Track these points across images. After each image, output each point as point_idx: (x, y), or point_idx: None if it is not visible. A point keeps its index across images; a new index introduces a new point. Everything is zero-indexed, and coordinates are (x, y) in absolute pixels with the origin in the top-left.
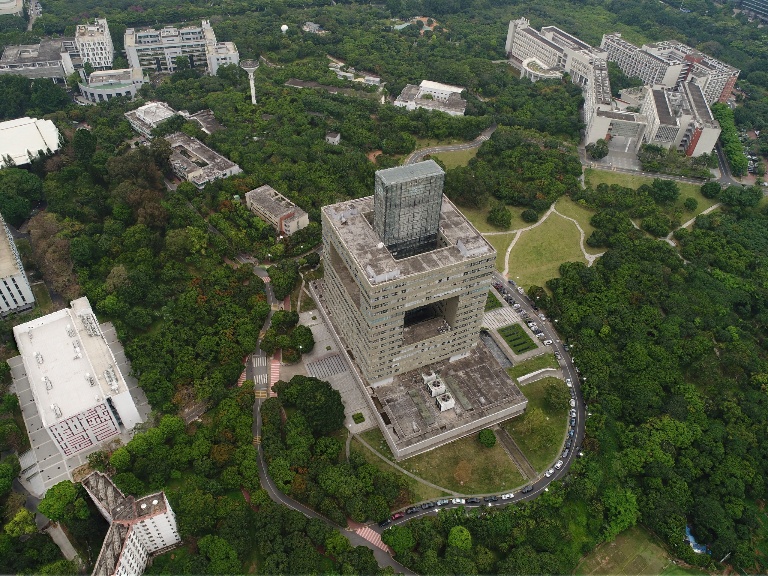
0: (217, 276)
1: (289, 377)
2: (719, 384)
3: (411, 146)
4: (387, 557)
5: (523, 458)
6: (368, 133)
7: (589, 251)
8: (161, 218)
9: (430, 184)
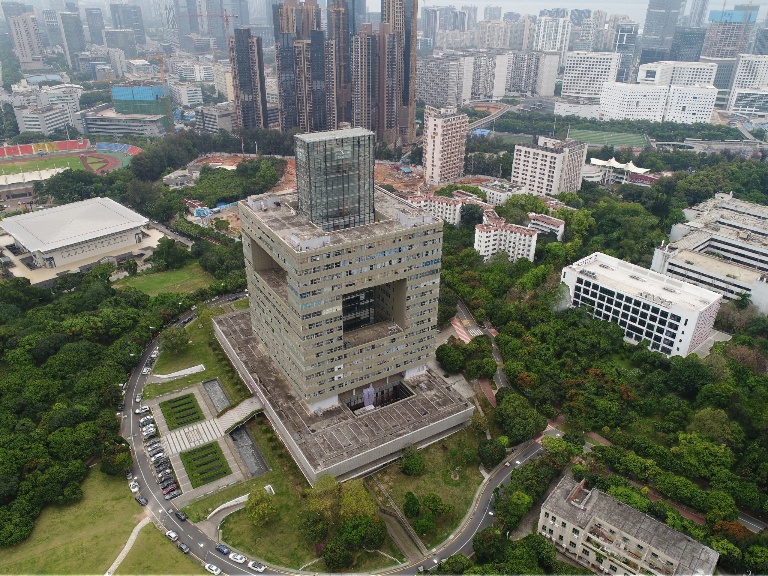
0: None
1: None
2: None
3: None
4: None
5: None
6: None
7: None
8: None
9: None
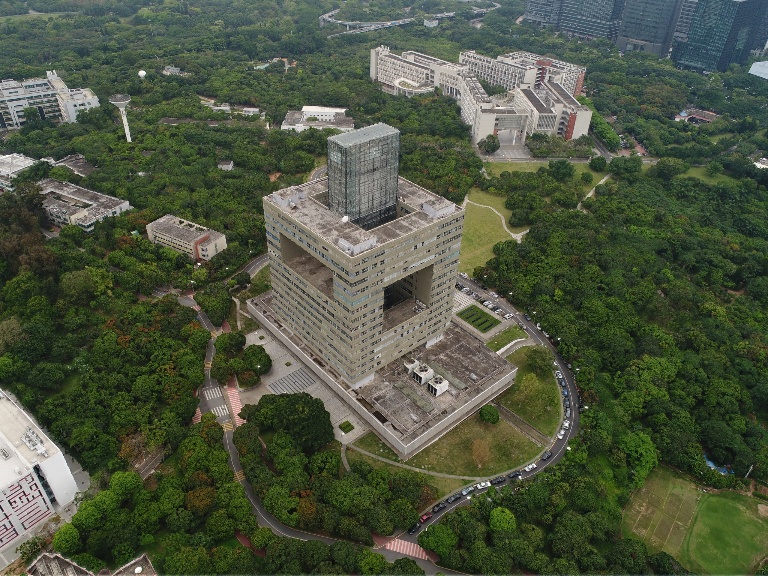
0: (136, 313)
1: (253, 402)
2: (678, 318)
3: (311, 163)
4: (429, 565)
5: (529, 427)
6: (263, 156)
7: (513, 231)
8: (51, 262)
9: (387, 145)
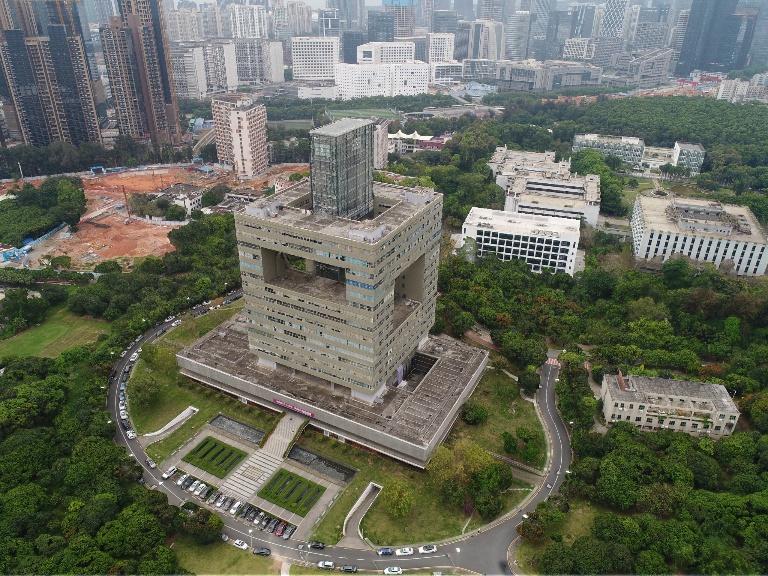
0: None
1: None
2: None
3: None
4: None
5: None
6: None
7: None
8: None
9: None
